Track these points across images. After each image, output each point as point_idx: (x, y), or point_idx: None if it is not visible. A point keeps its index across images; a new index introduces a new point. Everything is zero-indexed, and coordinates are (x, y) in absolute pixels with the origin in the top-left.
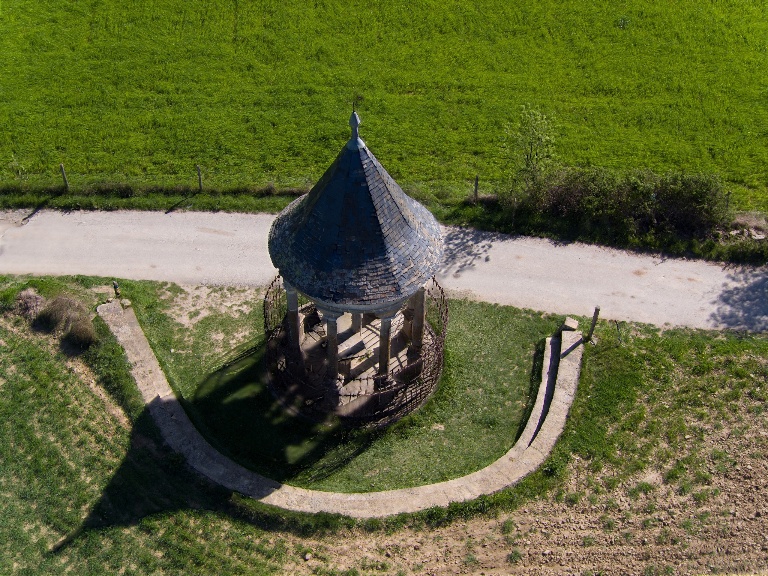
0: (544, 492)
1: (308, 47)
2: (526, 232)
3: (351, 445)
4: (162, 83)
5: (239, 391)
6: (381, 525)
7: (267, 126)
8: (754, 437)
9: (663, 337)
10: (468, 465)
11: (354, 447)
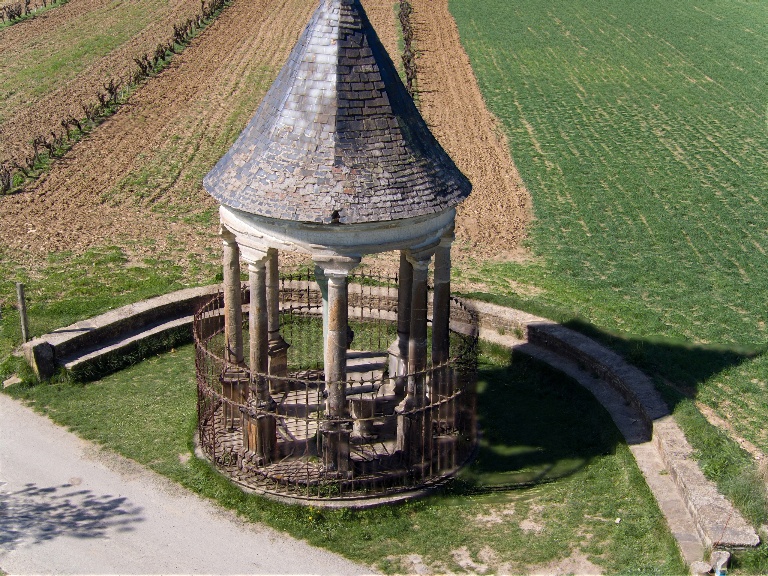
0: None
1: None
2: None
3: None
4: None
5: (526, 448)
6: None
7: None
8: (2, 261)
9: None
10: (290, 331)
11: None
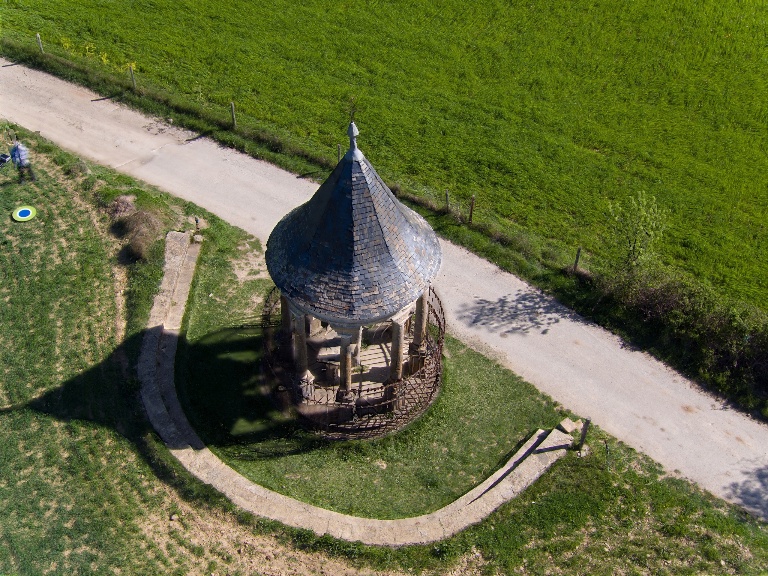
0: (420, 568)
1: (528, 74)
2: (601, 322)
3: (293, 443)
4: (377, 64)
5: (237, 353)
6: (253, 522)
7: (436, 133)
8: None
9: (661, 482)
10: (380, 511)
11: (294, 446)
